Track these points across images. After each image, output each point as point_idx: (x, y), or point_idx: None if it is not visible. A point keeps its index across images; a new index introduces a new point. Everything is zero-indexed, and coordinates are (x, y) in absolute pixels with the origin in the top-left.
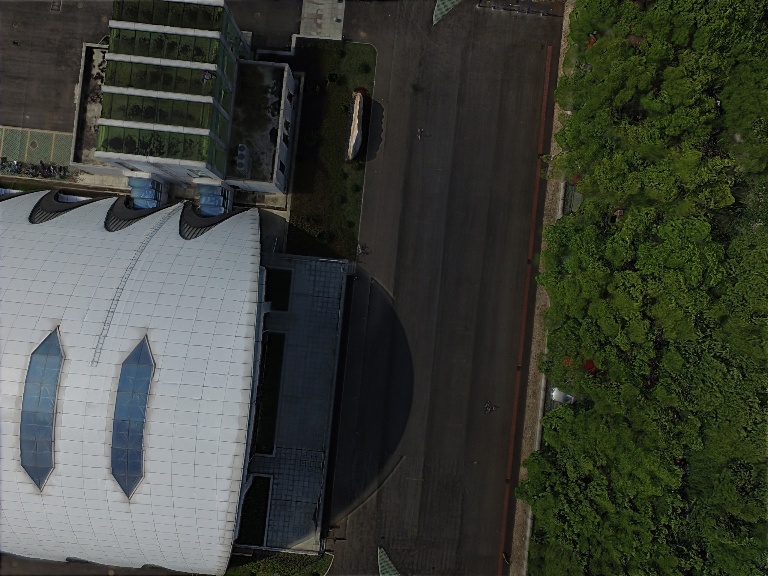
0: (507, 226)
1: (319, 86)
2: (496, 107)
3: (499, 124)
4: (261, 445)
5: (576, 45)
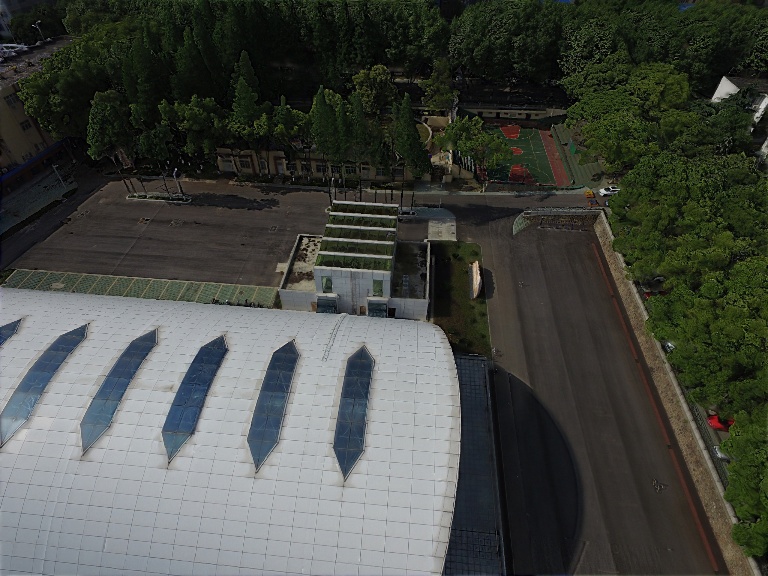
0: (608, 337)
1: None
2: (570, 271)
3: (576, 279)
4: None
5: (617, 219)
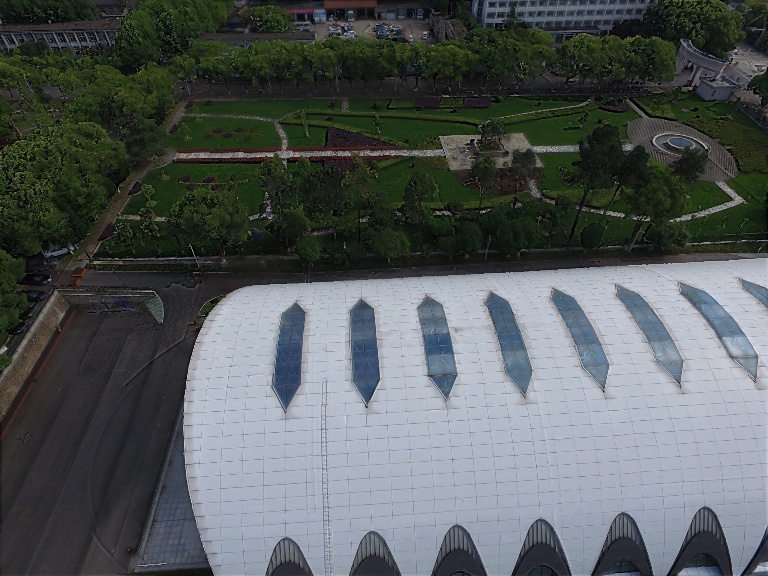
0: None
1: None
2: None
3: None
4: None
5: None
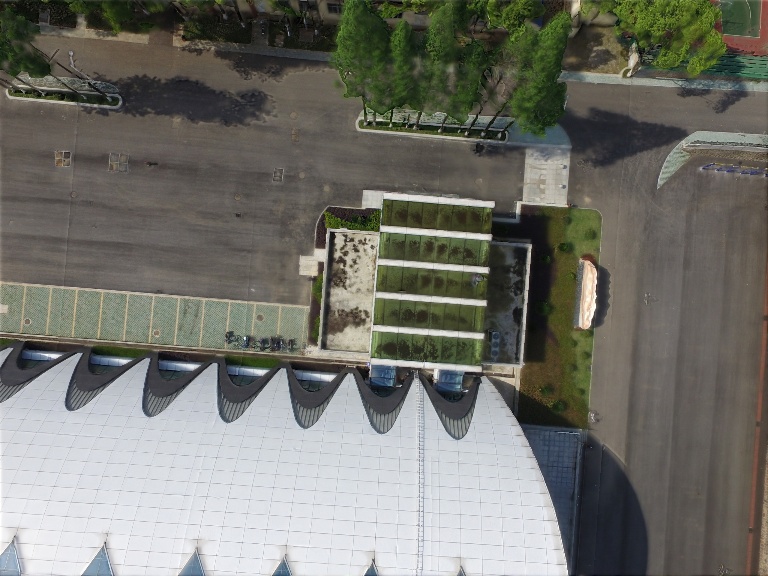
0: (735, 389)
1: (547, 254)
2: (722, 270)
3: (725, 287)
4: None
5: None
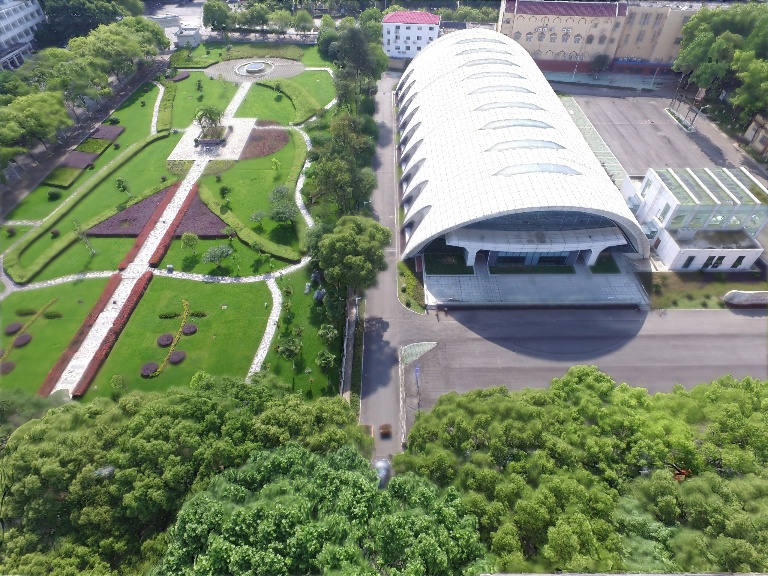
0: None
1: (759, 278)
2: None
3: None
4: (495, 268)
5: None
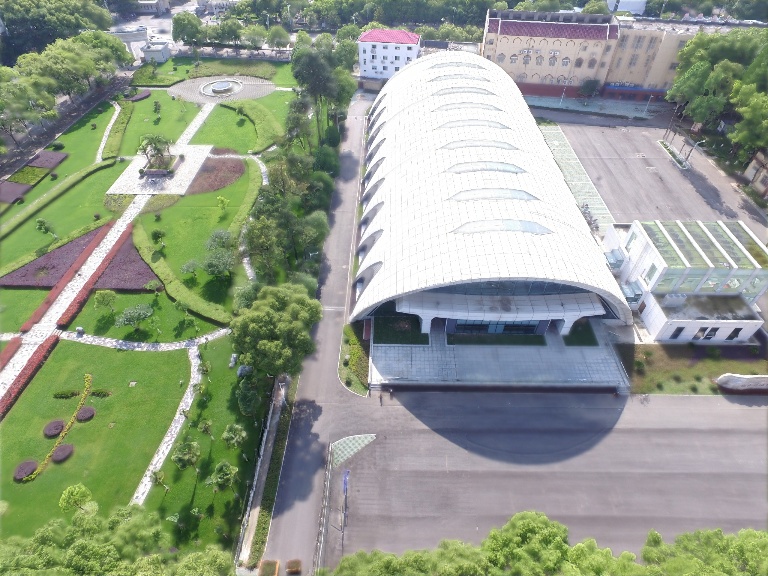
0: None
1: (759, 354)
2: None
3: None
4: (454, 336)
5: None
